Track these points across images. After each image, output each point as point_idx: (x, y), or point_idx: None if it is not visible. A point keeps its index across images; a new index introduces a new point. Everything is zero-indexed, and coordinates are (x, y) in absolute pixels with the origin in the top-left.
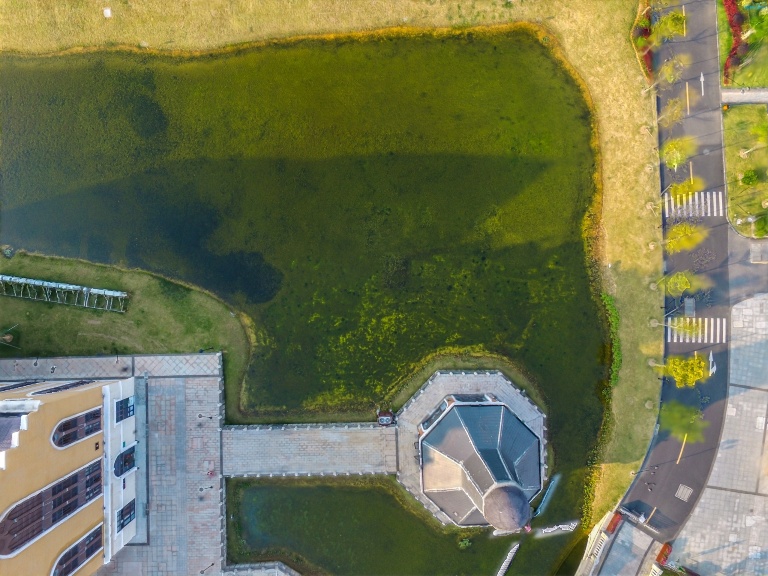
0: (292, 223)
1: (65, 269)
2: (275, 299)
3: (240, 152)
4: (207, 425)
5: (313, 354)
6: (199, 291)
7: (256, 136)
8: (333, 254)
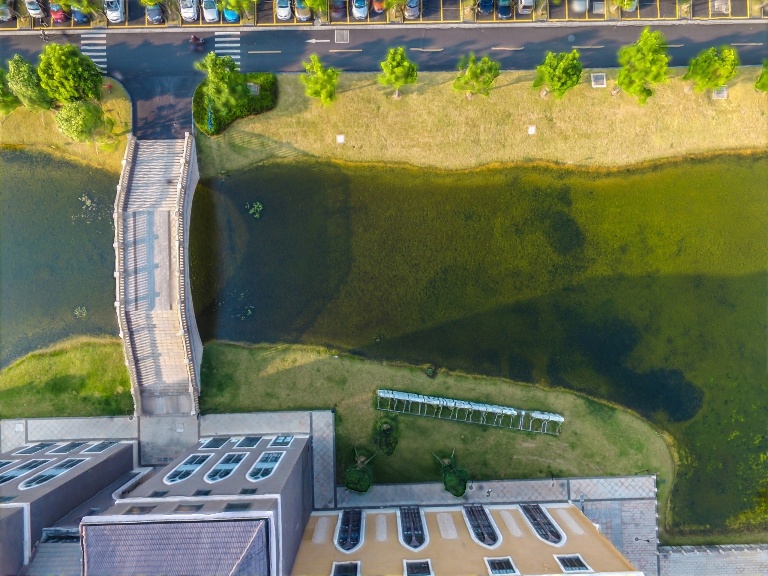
0: (711, 340)
1: (490, 389)
2: (696, 417)
3: (657, 268)
4: (644, 548)
5: (734, 472)
6: (623, 410)
7: (673, 252)
8: (753, 371)
